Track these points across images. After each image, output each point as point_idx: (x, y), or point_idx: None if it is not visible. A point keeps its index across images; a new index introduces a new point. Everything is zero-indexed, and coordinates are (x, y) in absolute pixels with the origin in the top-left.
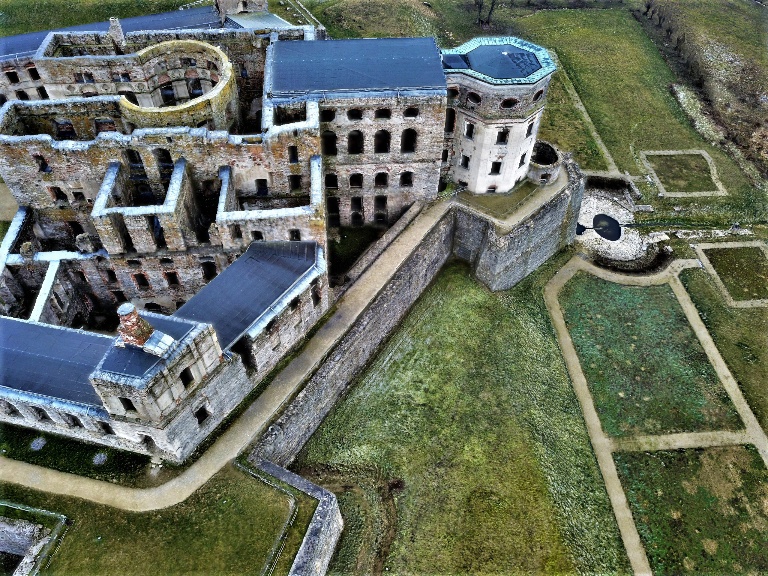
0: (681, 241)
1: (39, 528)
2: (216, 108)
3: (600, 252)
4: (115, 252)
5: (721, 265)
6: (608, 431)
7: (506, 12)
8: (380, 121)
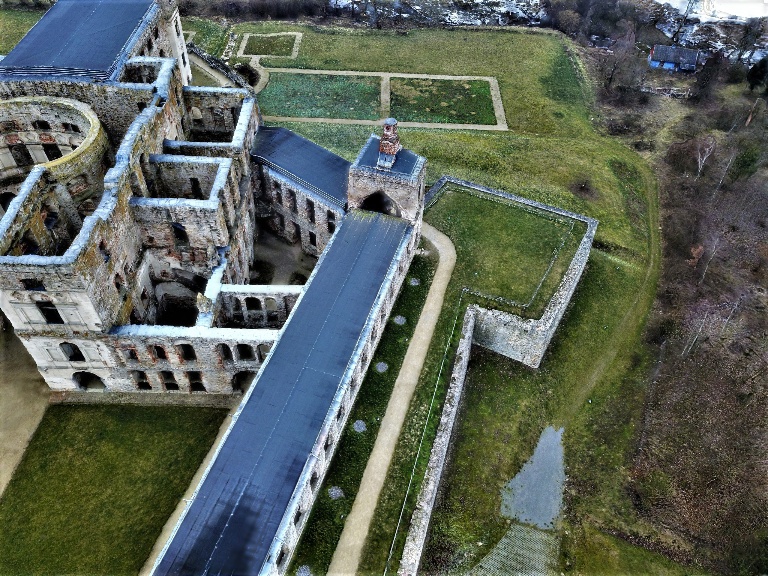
0: (233, 59)
1: (470, 308)
2: None
3: None
4: (227, 241)
5: (260, 52)
6: (376, 119)
7: None
8: (151, 54)
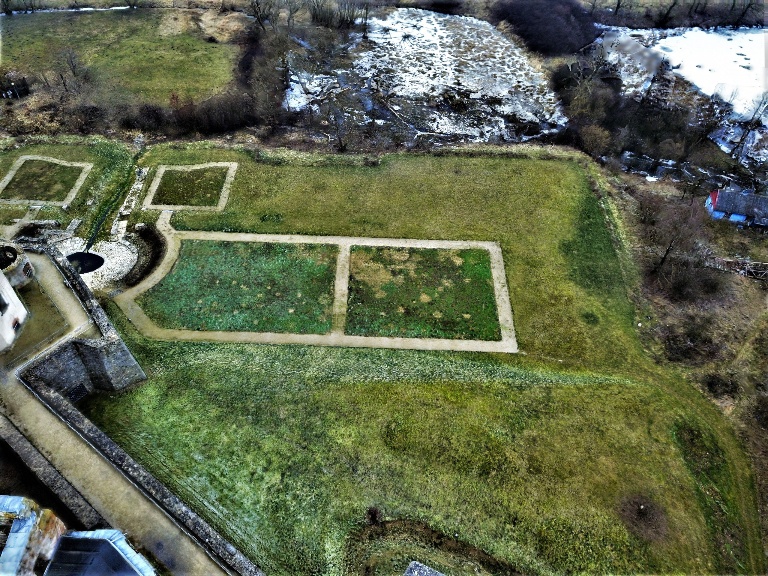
0: (135, 214)
1: None
2: None
3: (115, 278)
4: None
5: (175, 199)
6: (324, 331)
7: None
8: None
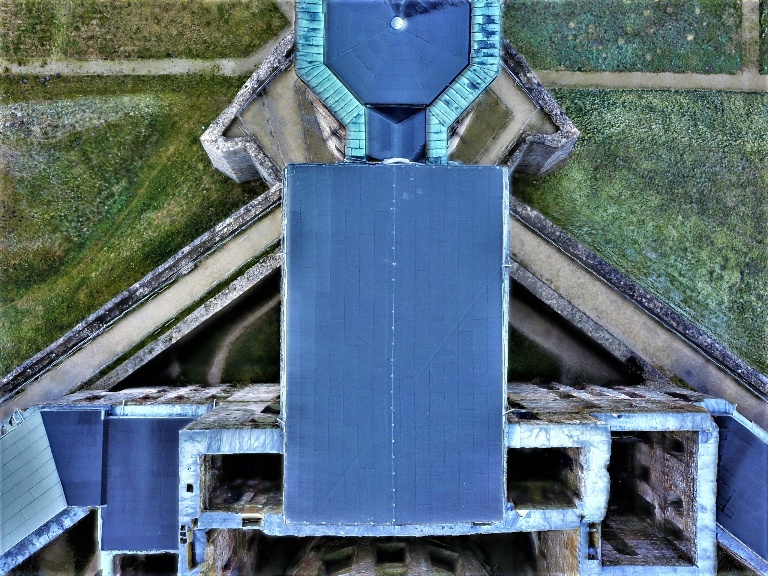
0: None
1: None
2: None
3: None
4: None
5: None
6: (735, 69)
7: None
8: None
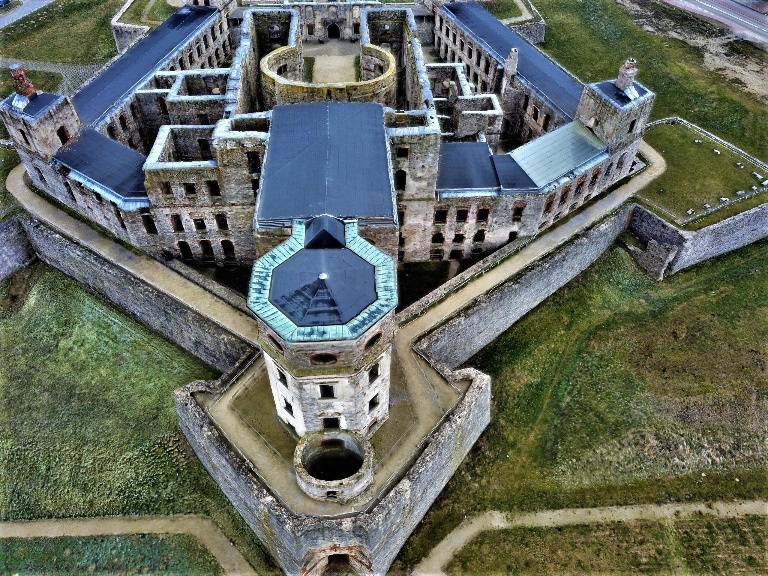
0: None
1: None
2: (279, 93)
3: None
4: None
5: None
6: None
7: None
8: None
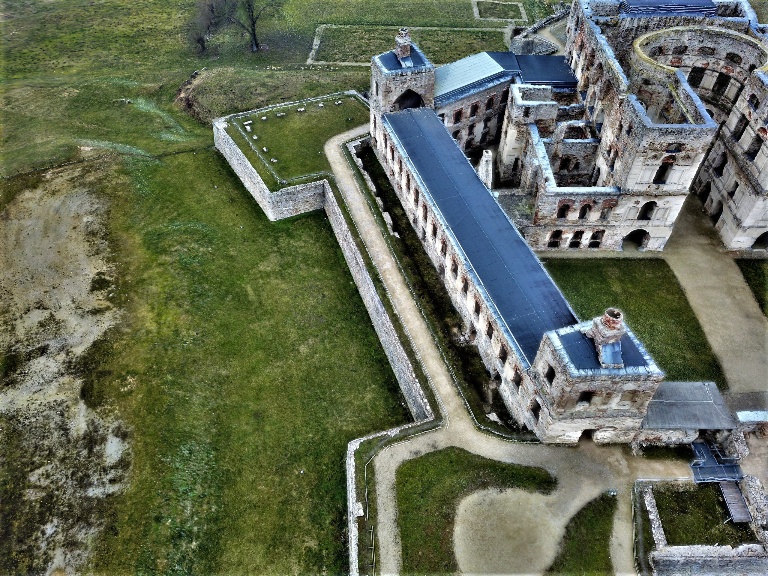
0: None
1: None
2: None
3: None
4: None
5: None
6: None
7: (227, 37)
8: None
